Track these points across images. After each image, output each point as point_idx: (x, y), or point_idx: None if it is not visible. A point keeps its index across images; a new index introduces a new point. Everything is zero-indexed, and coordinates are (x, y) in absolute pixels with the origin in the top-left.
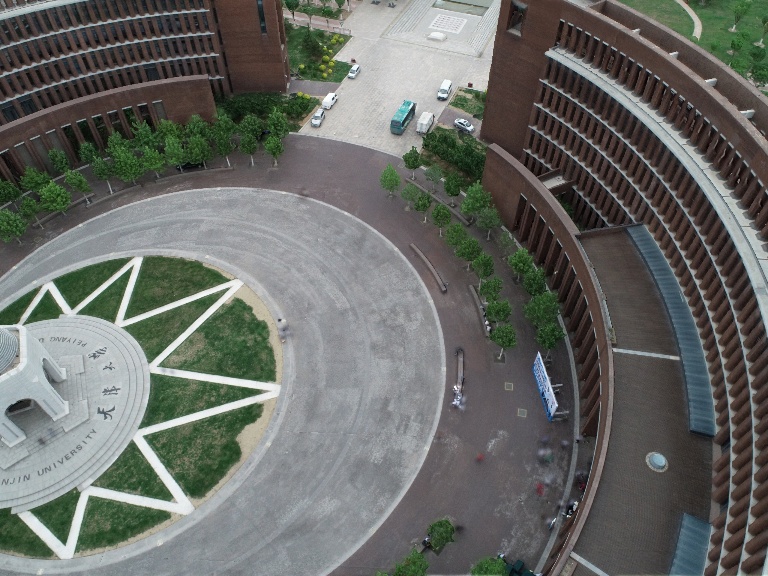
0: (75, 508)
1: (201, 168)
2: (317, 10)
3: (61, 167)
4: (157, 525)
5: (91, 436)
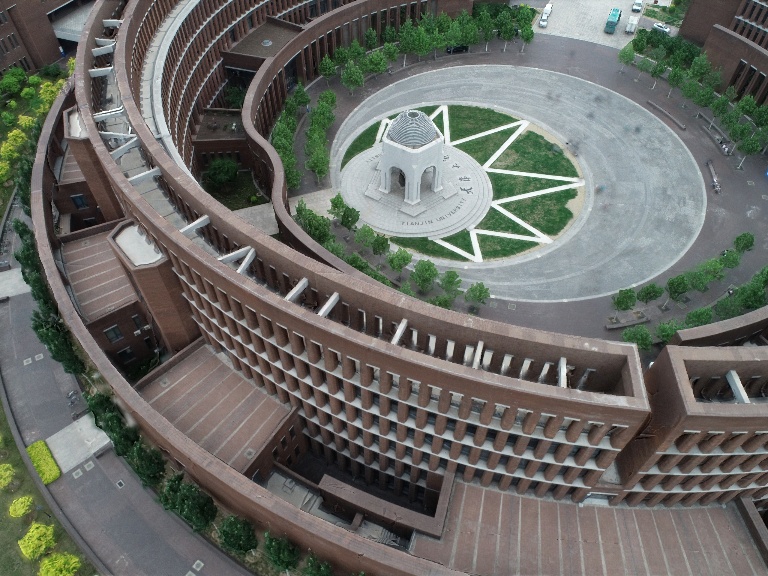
0: (470, 239)
1: (465, 52)
2: None
3: (374, 43)
4: (532, 248)
5: (463, 202)
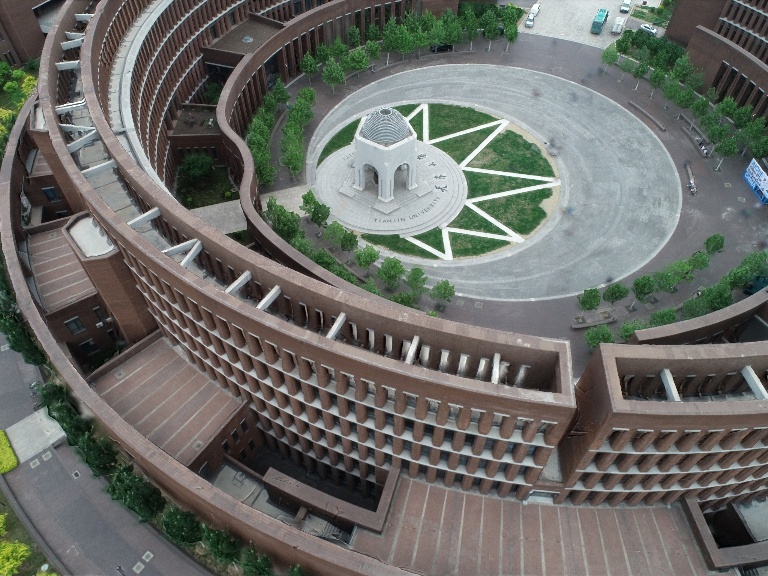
0: (442, 237)
1: (449, 51)
2: None
3: (357, 40)
4: (503, 247)
5: (437, 200)
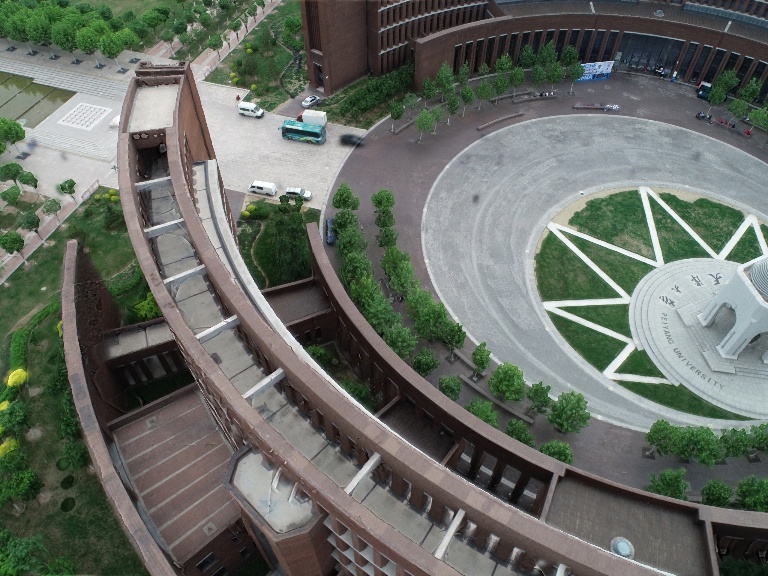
0: None
1: None
2: (4, 225)
3: None
4: None
5: None
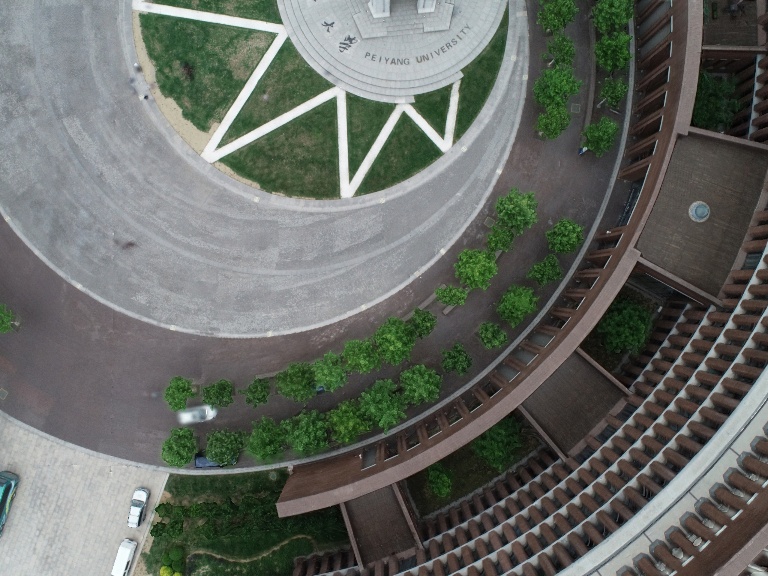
0: None
1: None
2: None
3: None
4: None
5: None
